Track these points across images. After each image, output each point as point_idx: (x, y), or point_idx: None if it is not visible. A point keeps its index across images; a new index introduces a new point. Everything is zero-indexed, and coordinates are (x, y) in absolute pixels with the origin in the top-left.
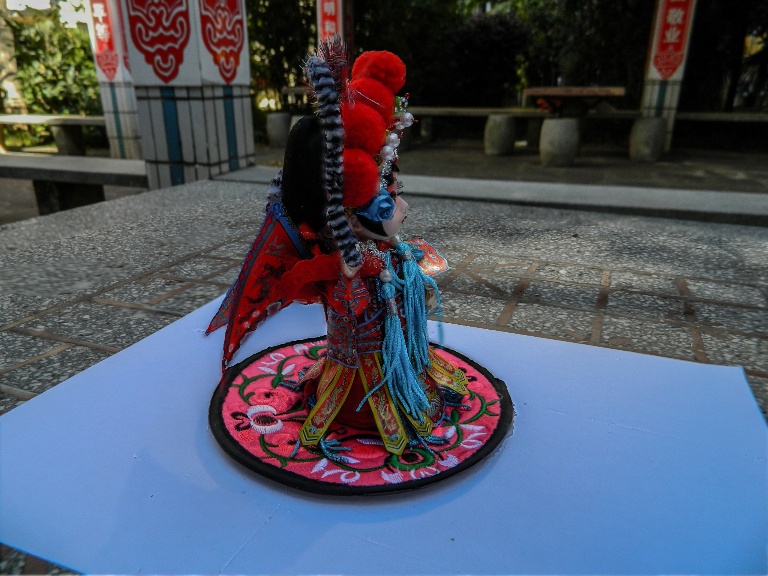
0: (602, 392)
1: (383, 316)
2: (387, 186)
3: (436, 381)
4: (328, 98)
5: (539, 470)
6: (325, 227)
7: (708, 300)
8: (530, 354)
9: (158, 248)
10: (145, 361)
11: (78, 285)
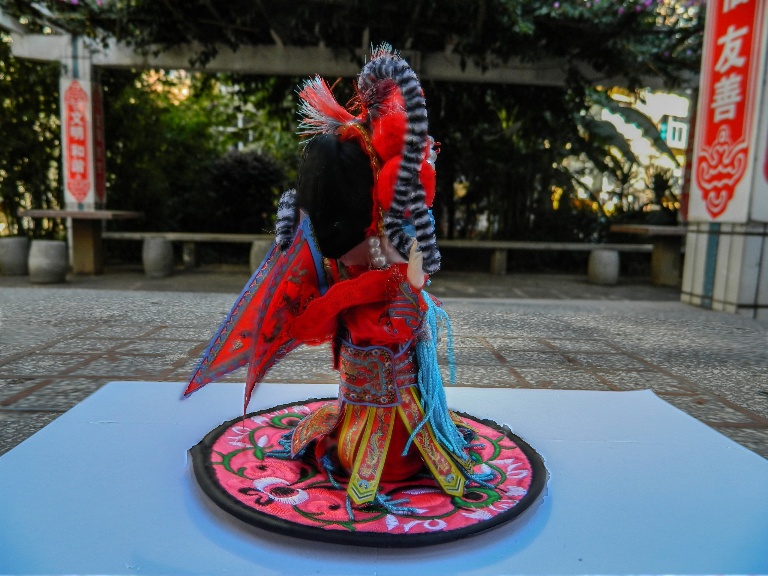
0: (574, 420)
1: (414, 346)
2: None
3: None
4: (416, 90)
5: (590, 486)
6: (353, 249)
7: (575, 351)
8: (486, 400)
9: None
10: (51, 462)
11: None
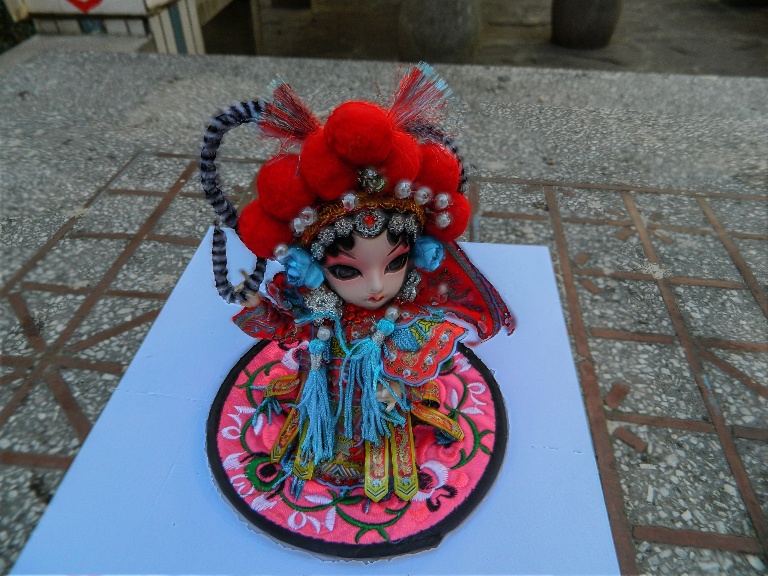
0: None
1: None
2: (327, 256)
3: (366, 460)
4: None
5: None
6: None
7: None
8: None
9: (615, 161)
10: None
11: (493, 164)
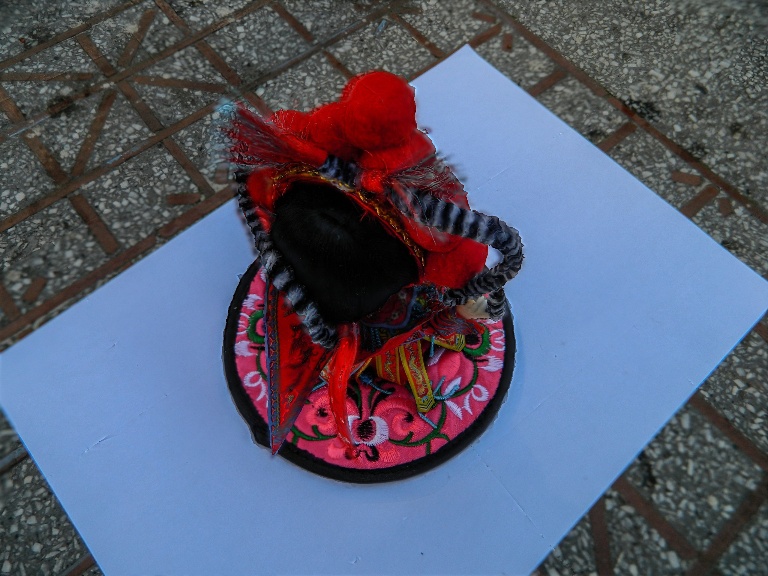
0: (450, 155)
1: None
2: None
3: None
4: None
5: None
6: None
7: None
8: None
9: None
10: (149, 527)
11: None
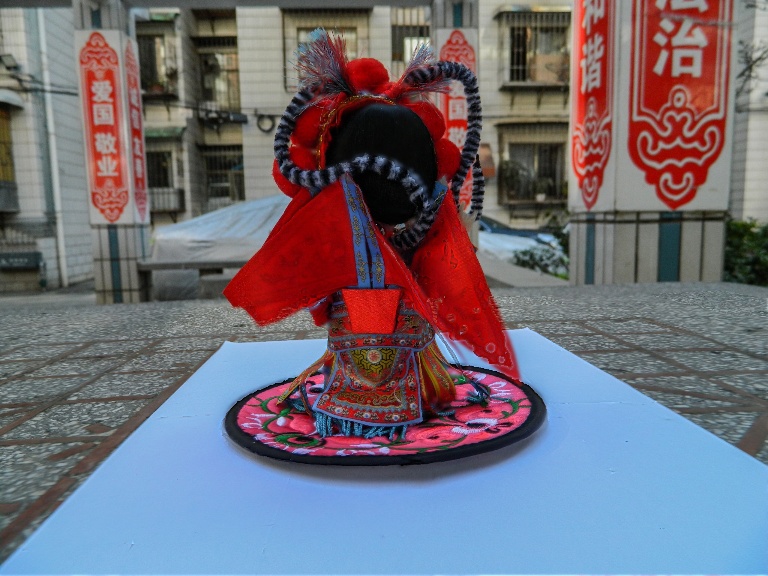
0: (291, 360)
1: None
2: None
3: None
4: None
5: None
6: None
7: (63, 354)
8: (230, 380)
9: None
10: None
11: None
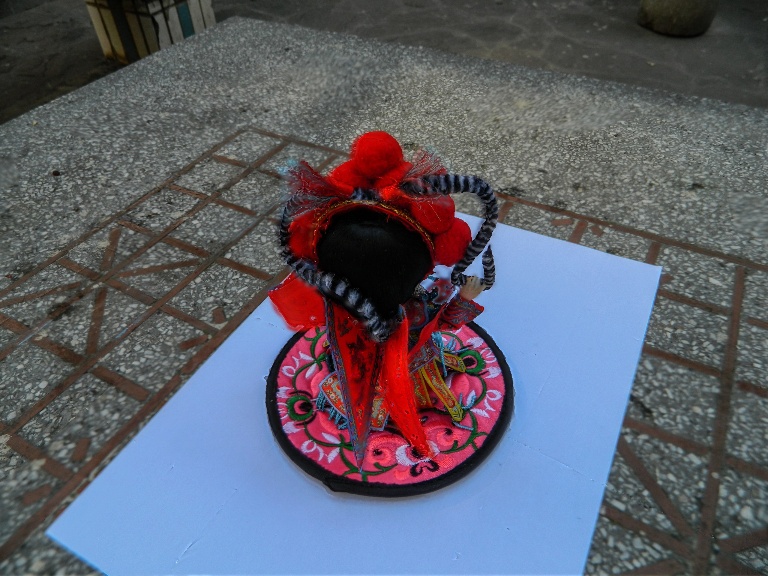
0: None
1: None
2: None
3: None
4: None
5: None
6: None
7: (260, 160)
8: None
9: None
10: None
11: None
